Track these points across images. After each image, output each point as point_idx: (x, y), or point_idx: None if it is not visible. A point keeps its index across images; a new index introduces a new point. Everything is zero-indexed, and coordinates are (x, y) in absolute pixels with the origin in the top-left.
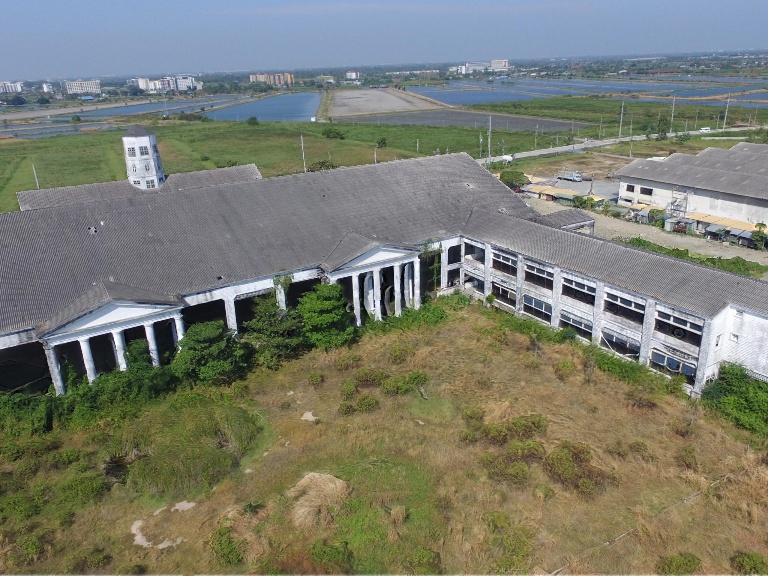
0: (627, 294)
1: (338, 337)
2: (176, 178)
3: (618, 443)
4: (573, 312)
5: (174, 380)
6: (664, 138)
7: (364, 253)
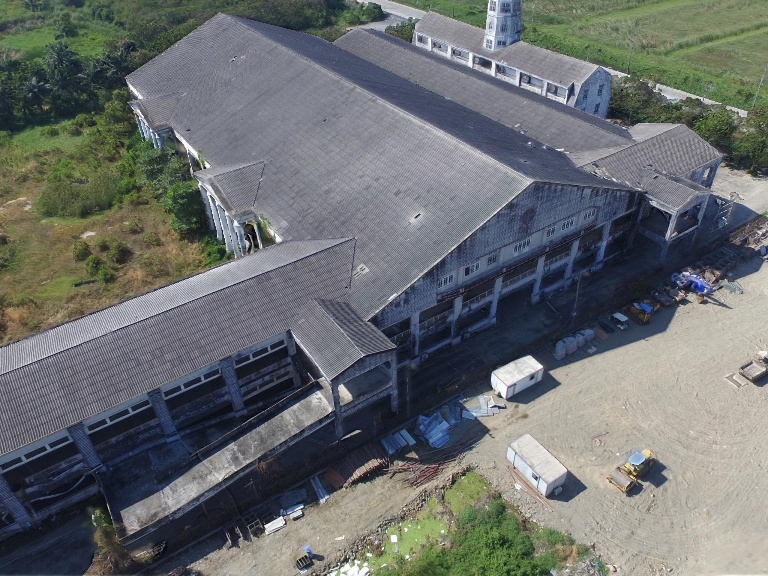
0: None
1: None
2: (518, 47)
3: None
4: None
5: None
6: None
7: None
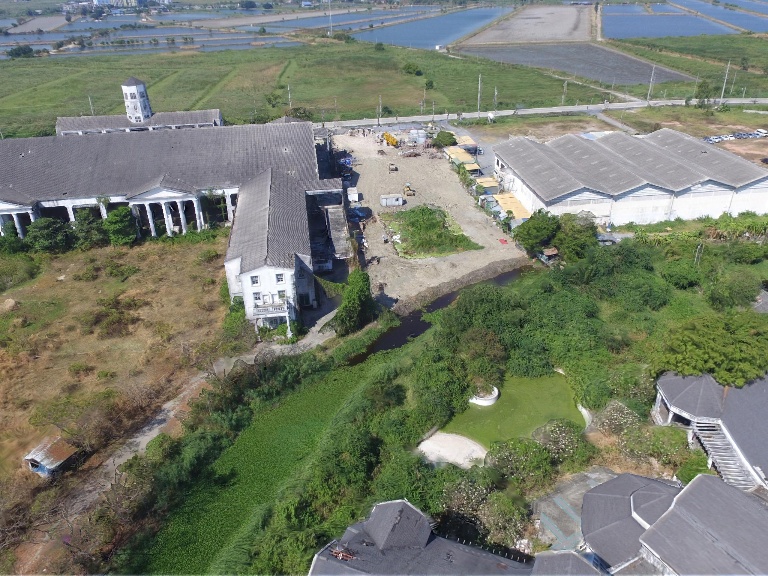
0: None
1: (123, 240)
2: (159, 116)
3: (156, 321)
4: None
5: (28, 246)
6: (702, 106)
7: (149, 191)
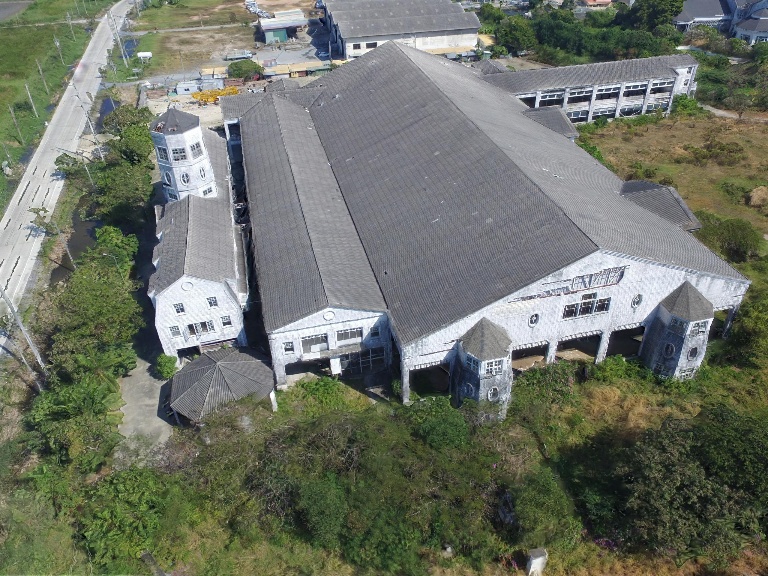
0: (638, 82)
1: None
2: None
3: (705, 138)
4: (603, 107)
5: None
6: (161, 4)
7: None
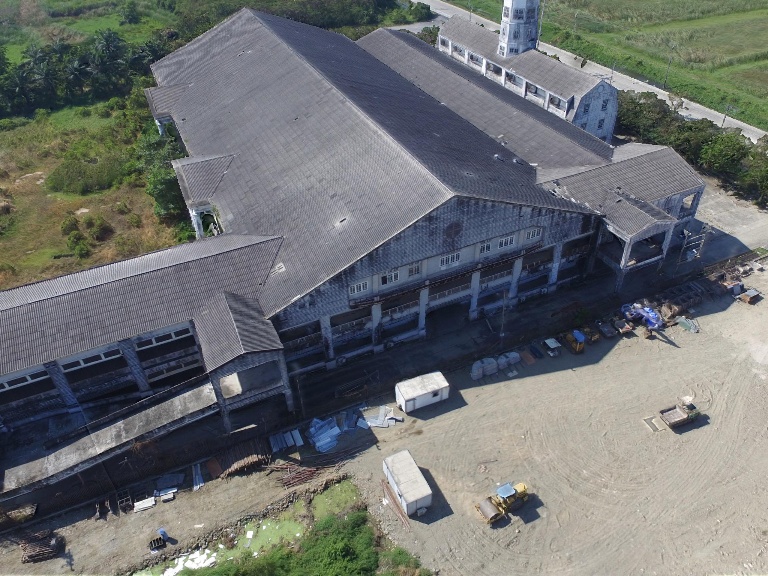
0: None
1: None
2: (529, 56)
3: None
4: None
5: None
6: None
7: None
